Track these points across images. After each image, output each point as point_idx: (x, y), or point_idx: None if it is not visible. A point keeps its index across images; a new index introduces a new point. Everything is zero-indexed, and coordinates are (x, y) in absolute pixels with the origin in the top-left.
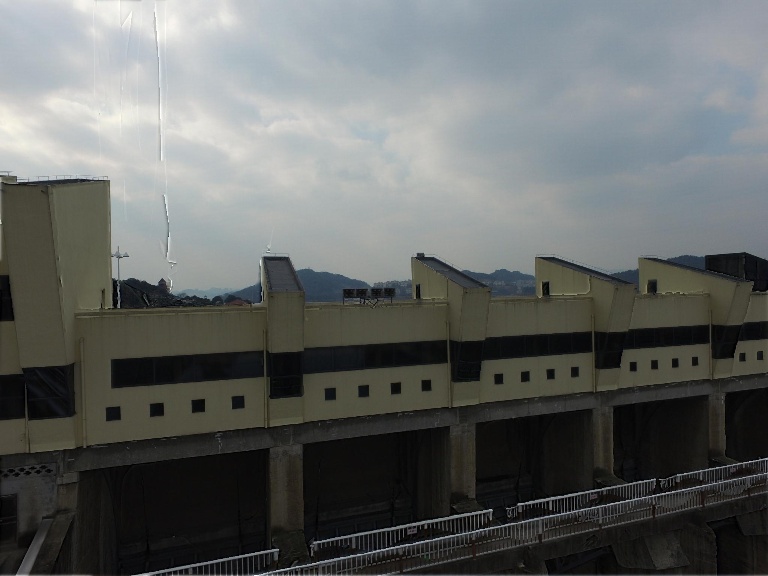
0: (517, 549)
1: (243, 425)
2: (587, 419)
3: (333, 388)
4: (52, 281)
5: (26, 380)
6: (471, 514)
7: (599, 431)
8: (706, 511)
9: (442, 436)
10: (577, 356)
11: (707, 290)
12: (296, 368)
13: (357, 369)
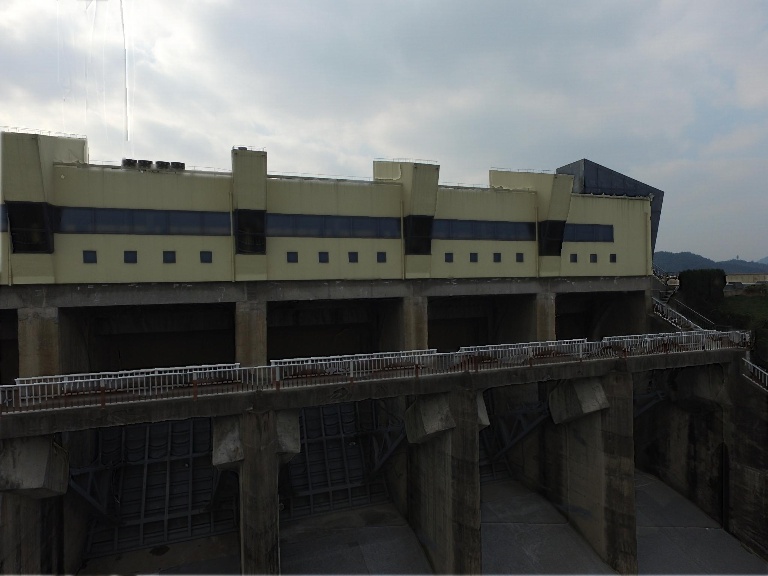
0: (248, 394)
1: None
2: (400, 309)
3: (93, 251)
4: None
5: None
6: (213, 366)
7: (411, 320)
8: (479, 376)
9: None
10: (384, 241)
11: (534, 188)
12: (42, 222)
13: (122, 233)
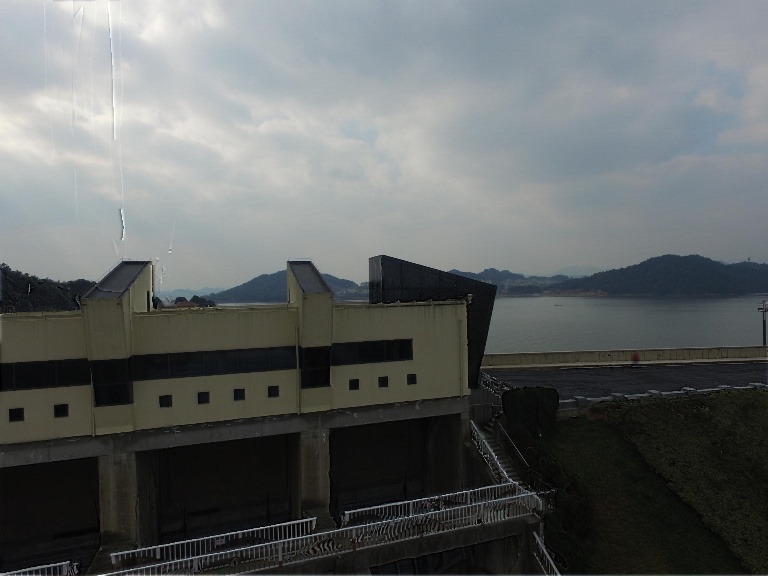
0: None
1: None
2: None
3: None
4: None
5: None
6: None
7: (110, 484)
8: None
9: None
10: (66, 390)
11: (295, 302)
12: None
13: None
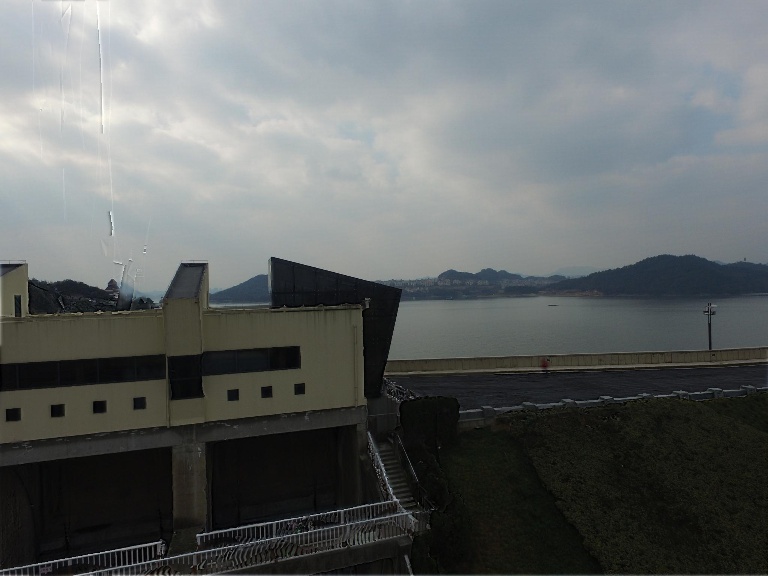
0: None
1: None
2: None
3: None
4: None
5: None
6: None
7: None
8: None
9: None
10: None
11: None
12: None
13: None
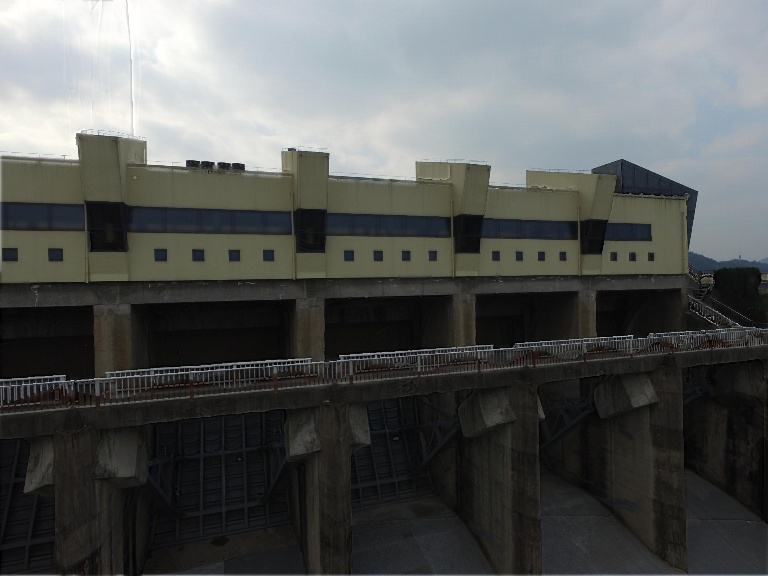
0: (324, 387)
1: (62, 279)
2: (449, 307)
3: (164, 249)
4: None
5: None
6: None
7: (460, 317)
8: (537, 371)
9: (293, 314)
10: (435, 240)
11: (576, 188)
12: (118, 222)
13: (191, 232)
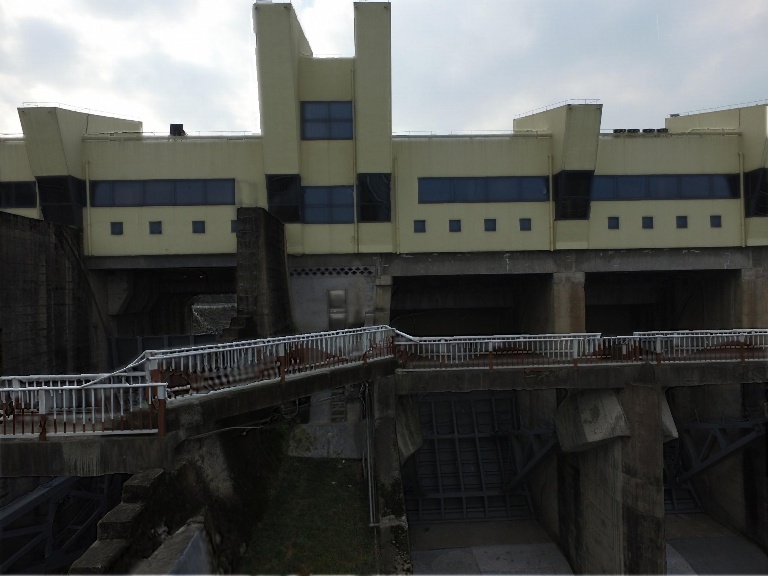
0: None
1: (530, 247)
2: None
3: (616, 217)
4: (385, 93)
5: (360, 185)
6: None
7: None
8: None
9: (726, 286)
10: None
11: None
12: (584, 190)
13: (640, 199)
